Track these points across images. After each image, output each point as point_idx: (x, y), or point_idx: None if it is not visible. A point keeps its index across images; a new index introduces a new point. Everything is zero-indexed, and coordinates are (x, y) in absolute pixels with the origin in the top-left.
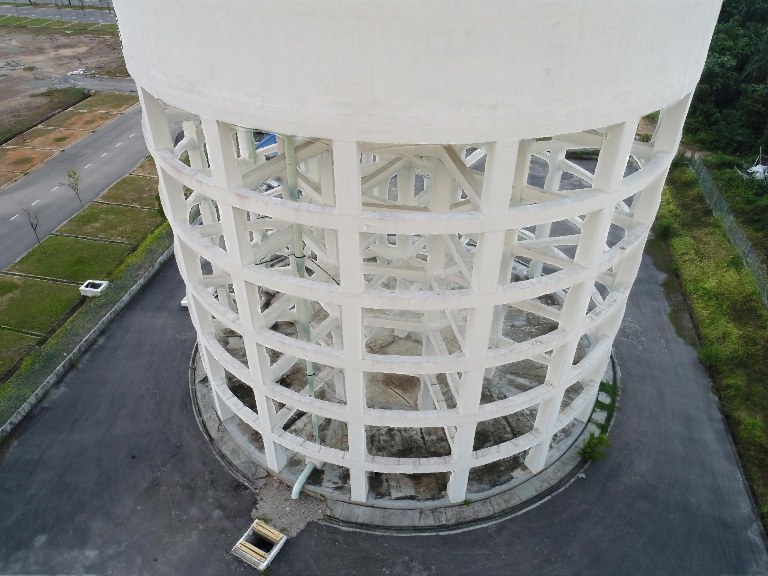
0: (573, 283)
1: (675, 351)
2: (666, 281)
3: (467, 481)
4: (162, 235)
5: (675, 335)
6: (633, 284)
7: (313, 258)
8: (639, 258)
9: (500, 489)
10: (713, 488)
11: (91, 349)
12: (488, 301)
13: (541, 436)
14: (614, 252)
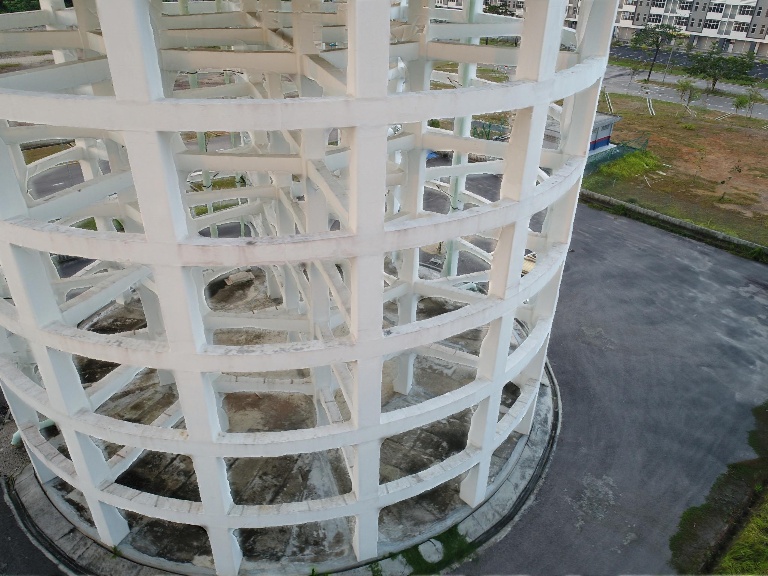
0: (125, 257)
1: (635, 561)
2: (743, 463)
3: (112, 521)
4: (237, 200)
5: (665, 540)
6: (678, 441)
7: None
8: (360, 297)
9: (161, 563)
10: None
11: (80, 259)
12: (0, 232)
13: (199, 515)
14: (227, 242)
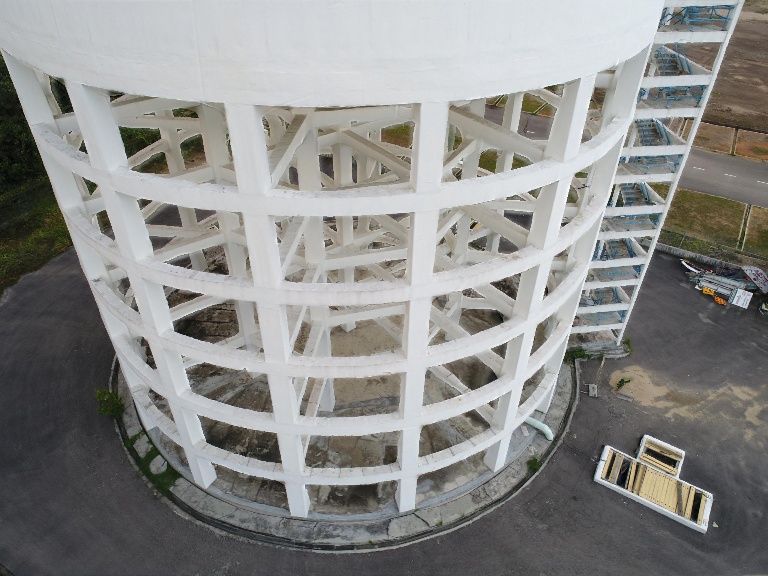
0: None
1: None
2: None
3: None
4: None
5: None
6: None
7: (515, 295)
8: None
9: None
10: (1, 505)
11: None
12: None
13: None
14: None
